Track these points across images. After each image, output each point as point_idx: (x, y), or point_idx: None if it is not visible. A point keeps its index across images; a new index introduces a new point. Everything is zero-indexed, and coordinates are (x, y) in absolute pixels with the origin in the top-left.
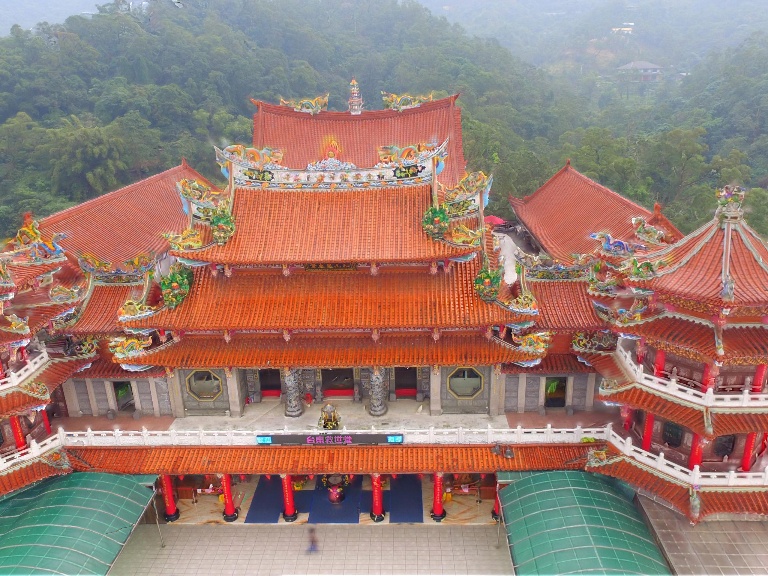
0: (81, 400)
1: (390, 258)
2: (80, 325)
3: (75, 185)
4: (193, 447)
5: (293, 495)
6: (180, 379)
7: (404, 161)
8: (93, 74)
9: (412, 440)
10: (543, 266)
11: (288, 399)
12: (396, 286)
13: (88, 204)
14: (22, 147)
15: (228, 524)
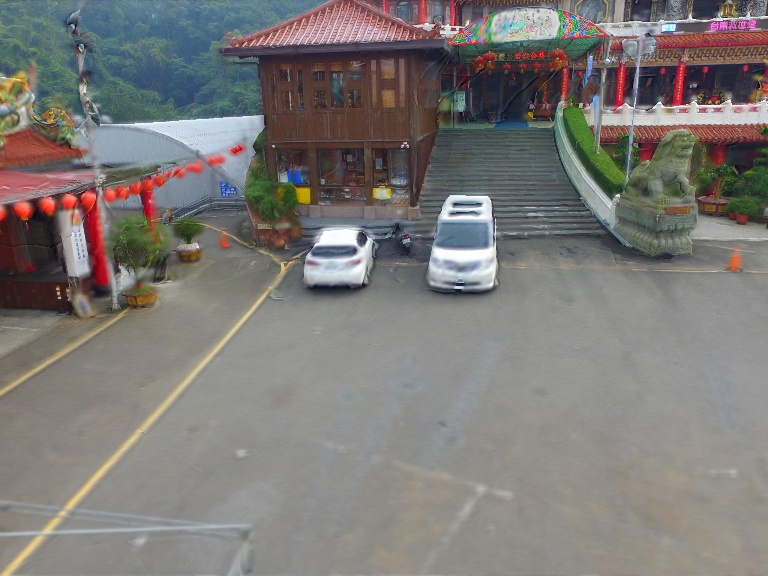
0: None
1: None
2: None
3: None
4: None
5: None
6: (571, 5)
7: None
8: (286, 13)
9: None
10: None
11: None
12: None
13: None
14: None
15: None
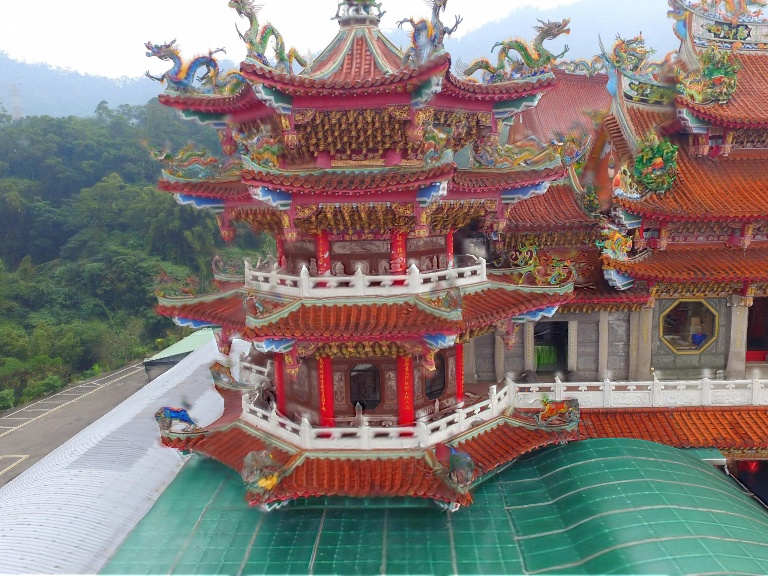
0: (479, 356)
1: None
2: (514, 221)
3: (169, 245)
4: (744, 407)
5: None
6: (653, 315)
7: None
8: (177, 147)
9: None
10: None
11: None
12: None
13: None
14: (110, 210)
15: None
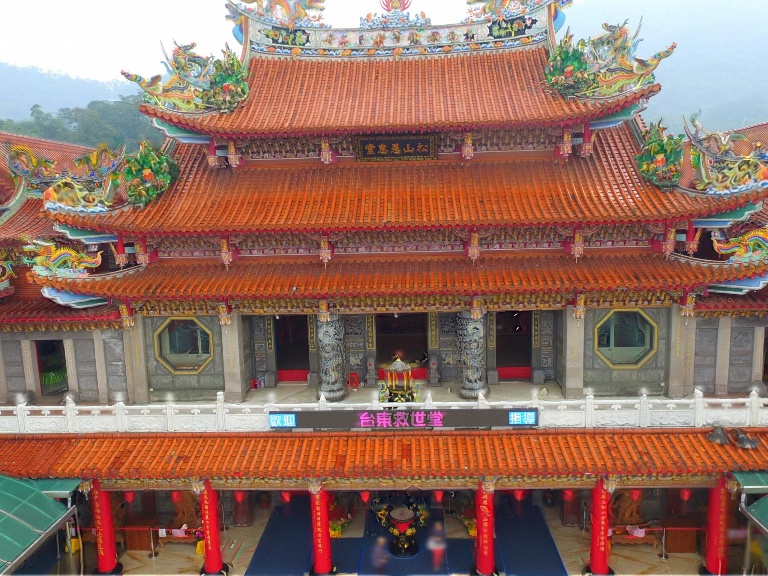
0: None
1: (499, 119)
2: None
3: None
4: (153, 434)
5: None
6: (144, 334)
7: (505, 11)
8: None
9: (553, 421)
10: (735, 154)
11: (323, 368)
12: (504, 177)
13: (50, 143)
14: None
15: None
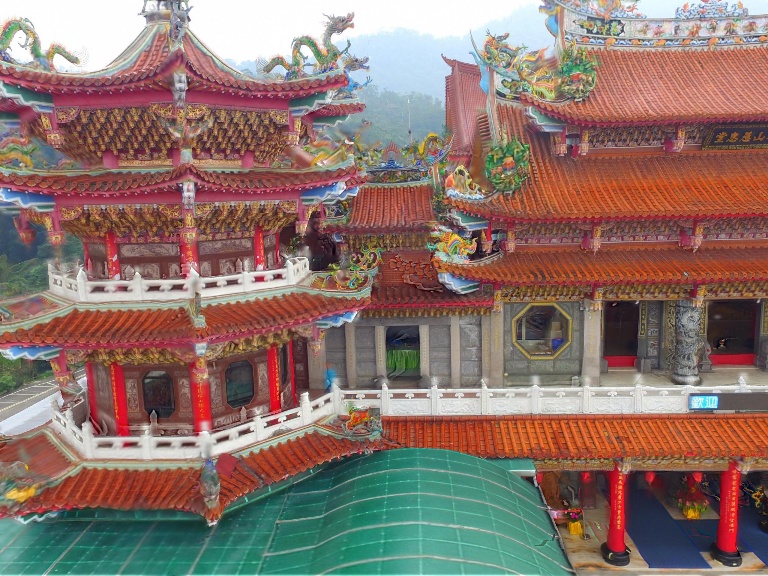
0: (331, 360)
1: None
2: (357, 222)
3: None
4: (573, 416)
5: (693, 526)
6: (504, 320)
7: None
8: None
9: None
10: None
11: (685, 353)
12: None
13: None
14: None
15: (619, 570)
